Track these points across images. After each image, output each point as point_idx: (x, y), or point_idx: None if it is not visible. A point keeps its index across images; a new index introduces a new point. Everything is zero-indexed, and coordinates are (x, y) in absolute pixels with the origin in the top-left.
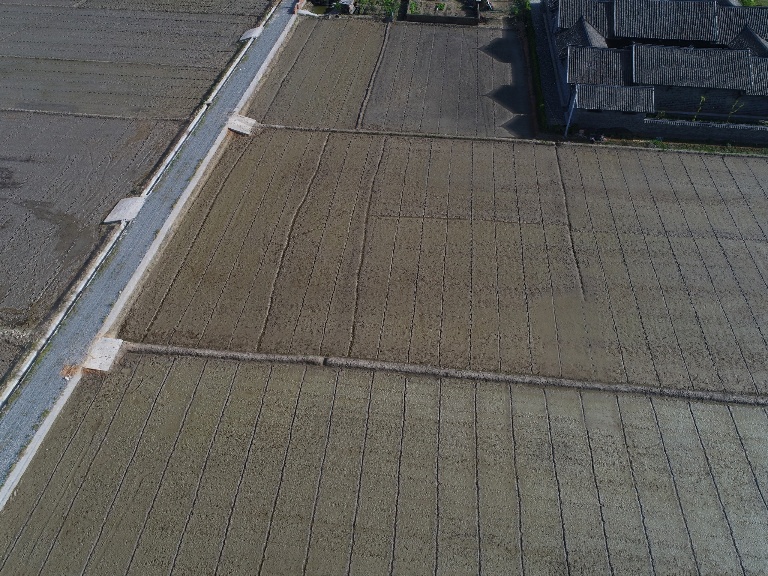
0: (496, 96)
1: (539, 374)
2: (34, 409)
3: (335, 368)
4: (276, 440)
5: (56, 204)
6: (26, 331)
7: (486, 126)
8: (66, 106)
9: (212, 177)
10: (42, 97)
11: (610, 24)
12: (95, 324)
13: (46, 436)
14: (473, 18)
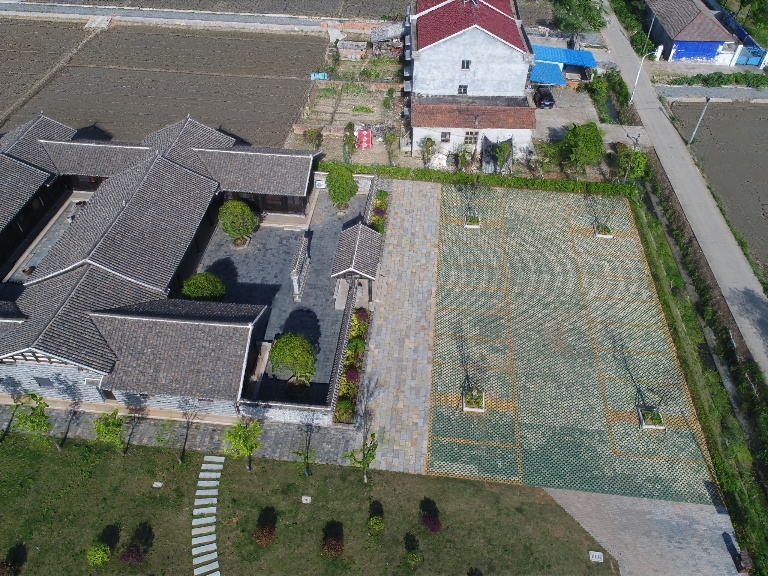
0: (87, 131)
1: None
2: None
3: None
4: None
5: None
6: None
7: (27, 121)
8: None
9: (35, 21)
10: None
11: None
12: None
13: None
14: (295, 120)
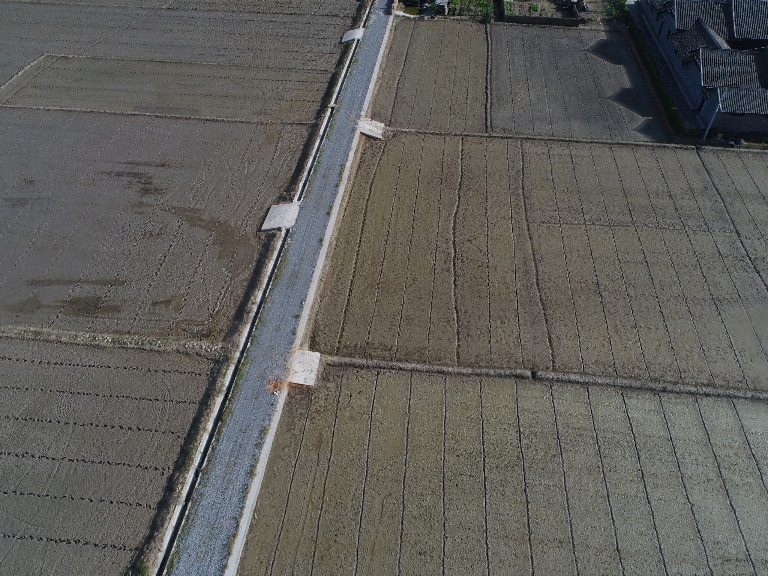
0: (619, 99)
1: (756, 388)
2: (252, 426)
3: (546, 382)
4: (509, 459)
5: (206, 211)
6: (216, 343)
7: (619, 130)
8: (185, 109)
9: (356, 183)
10: (158, 100)
11: (729, 25)
12: (287, 336)
13: (270, 454)
14: (574, 19)
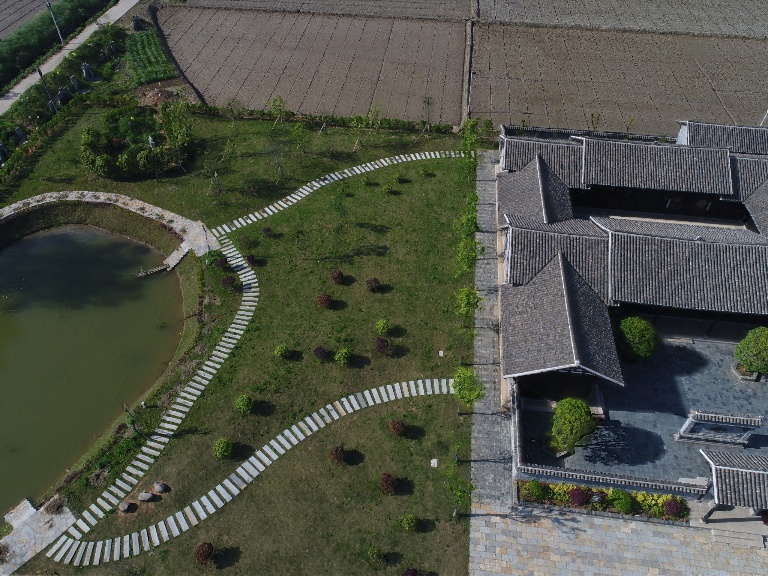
0: None
1: None
2: None
3: None
4: None
5: None
6: None
7: None
8: None
9: None
10: None
11: None
12: None
13: None
14: None
